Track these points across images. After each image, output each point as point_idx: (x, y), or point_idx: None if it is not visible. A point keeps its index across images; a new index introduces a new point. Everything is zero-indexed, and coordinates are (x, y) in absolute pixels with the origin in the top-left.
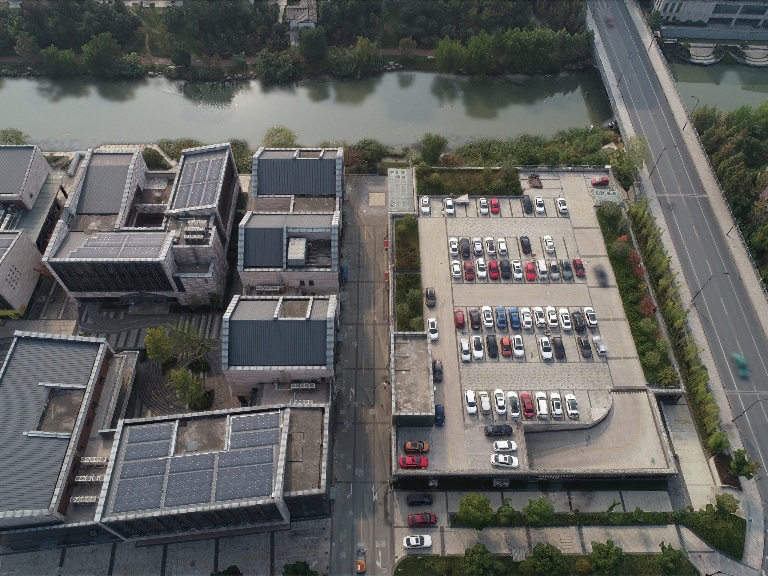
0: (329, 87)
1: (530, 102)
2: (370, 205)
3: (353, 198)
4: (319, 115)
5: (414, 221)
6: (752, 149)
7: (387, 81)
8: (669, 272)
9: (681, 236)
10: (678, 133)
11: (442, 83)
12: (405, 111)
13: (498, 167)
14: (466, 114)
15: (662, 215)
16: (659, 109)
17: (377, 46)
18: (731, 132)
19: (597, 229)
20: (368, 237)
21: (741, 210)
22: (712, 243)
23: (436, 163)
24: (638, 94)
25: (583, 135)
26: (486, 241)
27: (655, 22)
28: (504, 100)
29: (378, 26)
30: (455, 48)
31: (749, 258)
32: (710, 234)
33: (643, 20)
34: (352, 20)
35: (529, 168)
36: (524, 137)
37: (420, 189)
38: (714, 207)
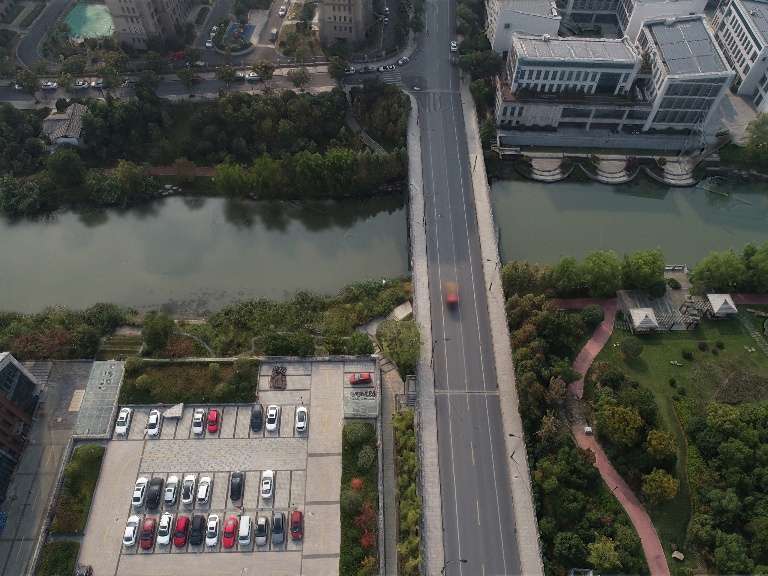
0: (86, 220)
1: (326, 239)
2: (69, 410)
3: (51, 399)
4: (59, 263)
5: (98, 450)
6: (559, 329)
7: (159, 210)
8: (422, 523)
9: (452, 459)
10: (483, 294)
11: (225, 213)
12: (167, 255)
13: (235, 358)
14: (243, 258)
15: (434, 426)
16: (467, 258)
17: (146, 169)
18: (539, 301)
19: (339, 456)
20: (50, 463)
21: (530, 424)
22: (490, 470)
23: (163, 348)
24: (447, 236)
25: (373, 292)
26: (183, 483)
27: (487, 132)
28: (294, 237)
29: (155, 140)
30: (232, 175)
31: (532, 497)
32: (490, 455)
33: (477, 127)
34: (125, 132)
35: (274, 359)
36: (299, 296)
37: (123, 396)
38: (504, 412)
